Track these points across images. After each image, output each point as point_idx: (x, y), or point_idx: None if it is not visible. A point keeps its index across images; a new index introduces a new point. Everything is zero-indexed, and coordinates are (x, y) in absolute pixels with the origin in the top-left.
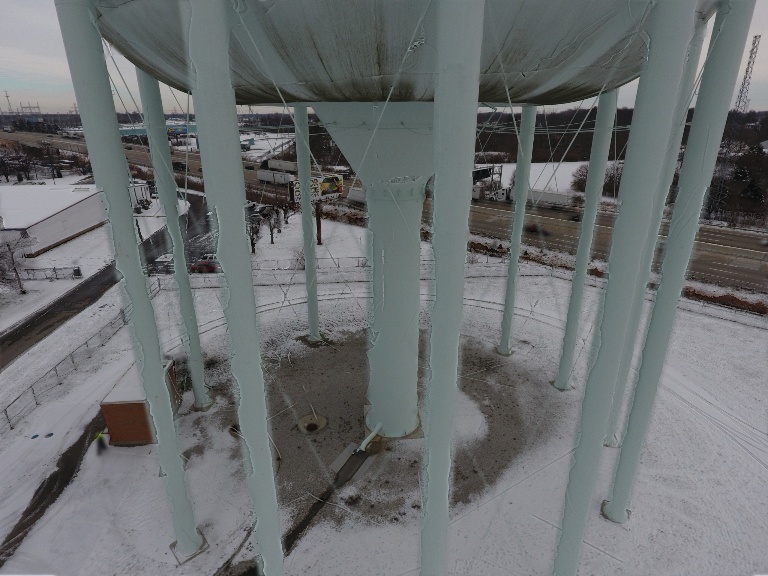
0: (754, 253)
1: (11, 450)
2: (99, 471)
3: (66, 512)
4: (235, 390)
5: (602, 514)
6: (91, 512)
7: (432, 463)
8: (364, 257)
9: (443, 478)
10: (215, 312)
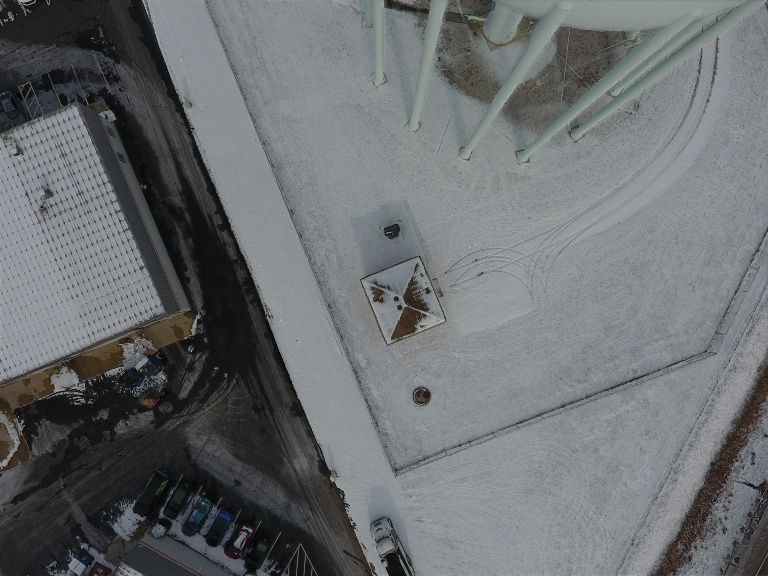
0: None
1: None
2: None
3: None
4: None
5: (462, 147)
6: None
7: None
8: None
9: (375, 35)
10: None
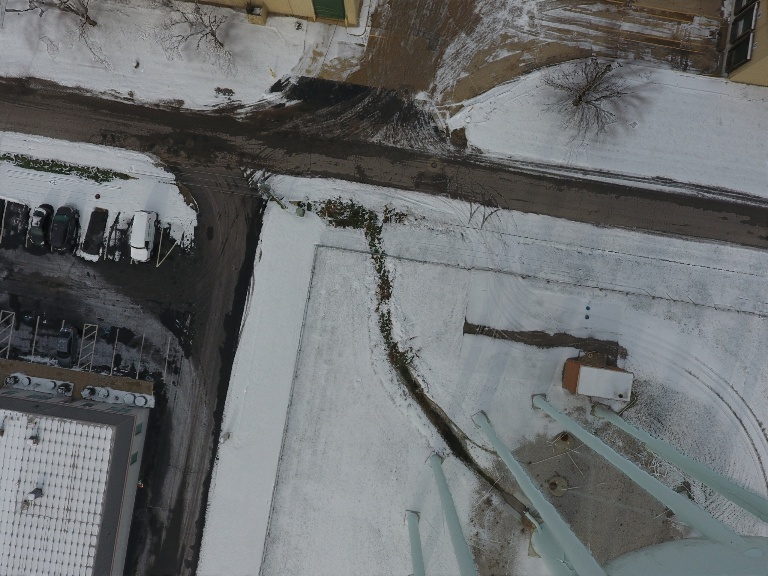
0: None
1: (577, 300)
2: (544, 360)
3: (516, 353)
4: (612, 432)
5: None
6: (513, 366)
7: (417, 575)
8: None
9: None
10: (767, 402)
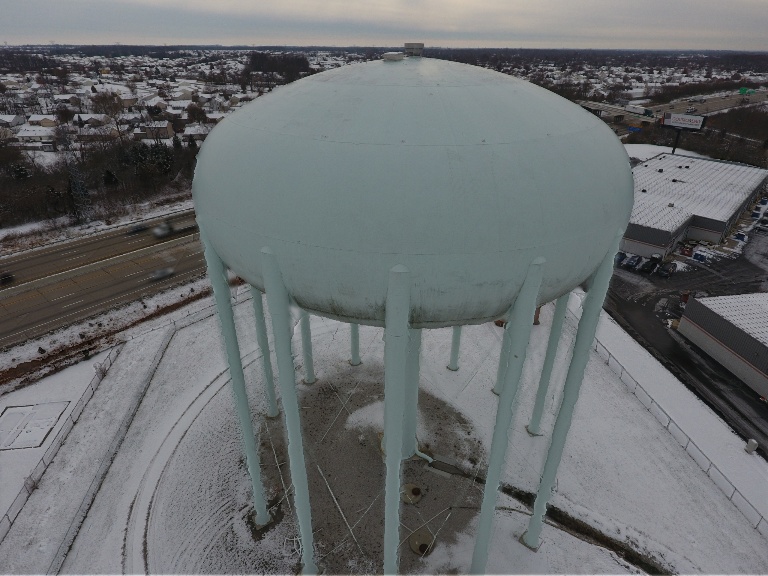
0: (187, 238)
1: None
2: None
3: None
4: (365, 575)
5: (455, 371)
6: None
7: None
8: (29, 477)
9: None
10: None
